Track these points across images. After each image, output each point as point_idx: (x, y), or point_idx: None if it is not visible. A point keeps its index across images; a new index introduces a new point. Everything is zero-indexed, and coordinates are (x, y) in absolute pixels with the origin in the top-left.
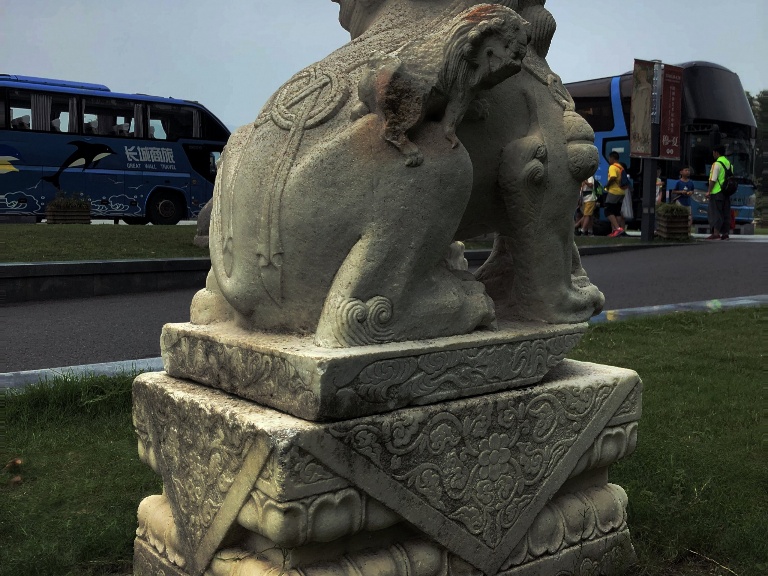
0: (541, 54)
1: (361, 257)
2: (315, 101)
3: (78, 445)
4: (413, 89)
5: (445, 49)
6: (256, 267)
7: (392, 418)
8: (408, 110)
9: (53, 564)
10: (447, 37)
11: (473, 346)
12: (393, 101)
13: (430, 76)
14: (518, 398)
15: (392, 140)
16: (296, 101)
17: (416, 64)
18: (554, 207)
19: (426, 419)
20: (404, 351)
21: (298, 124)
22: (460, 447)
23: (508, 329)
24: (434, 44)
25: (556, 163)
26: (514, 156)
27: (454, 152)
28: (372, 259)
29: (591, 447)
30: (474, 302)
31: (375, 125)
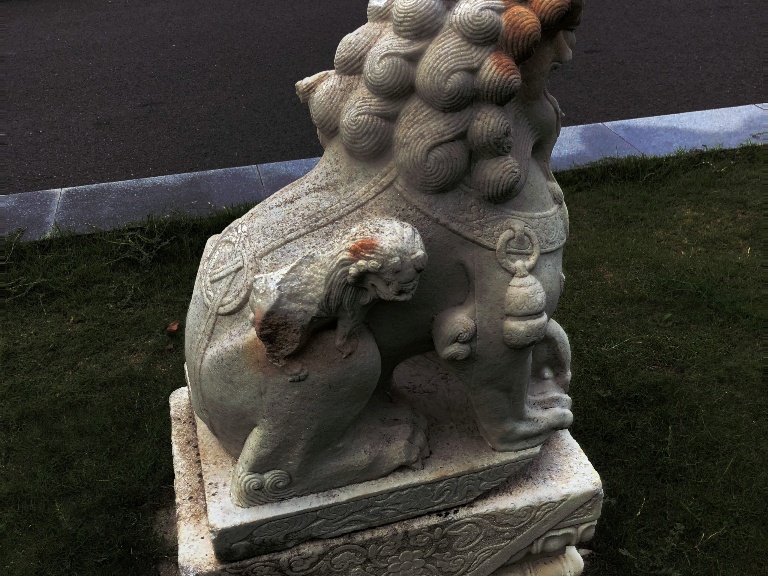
0: (504, 201)
1: (256, 443)
2: (228, 287)
3: None
4: (289, 322)
5: (327, 278)
6: (197, 404)
7: (290, 554)
8: (286, 340)
9: (134, 496)
10: (333, 263)
11: (382, 493)
12: (268, 335)
13: (310, 306)
14: (434, 525)
15: (273, 362)
16: (216, 279)
17: (297, 293)
18: (488, 373)
19: (327, 551)
20: (299, 511)
21: (213, 308)
22: (366, 564)
23: (437, 463)
24: (319, 270)
25: (488, 339)
26: (437, 335)
27: (346, 361)
28: (265, 446)
29: (529, 545)
30: (391, 453)
31: (261, 342)
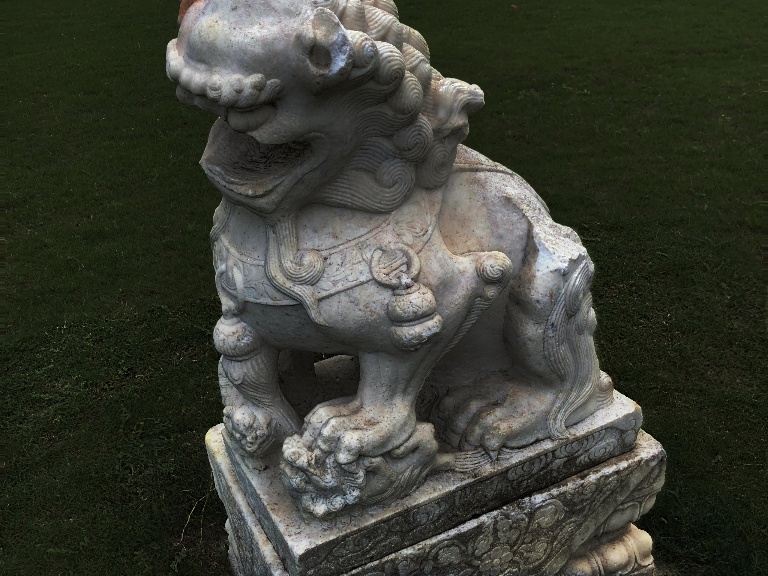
0: None
1: None
2: None
3: None
4: None
5: None
6: None
7: None
8: None
9: (718, 568)
10: None
11: None
12: None
13: None
14: None
15: None
16: None
17: None
18: None
19: None
20: None
21: None
22: None
23: (346, 357)
24: None
25: None
26: None
27: None
28: None
29: None
30: None
31: None
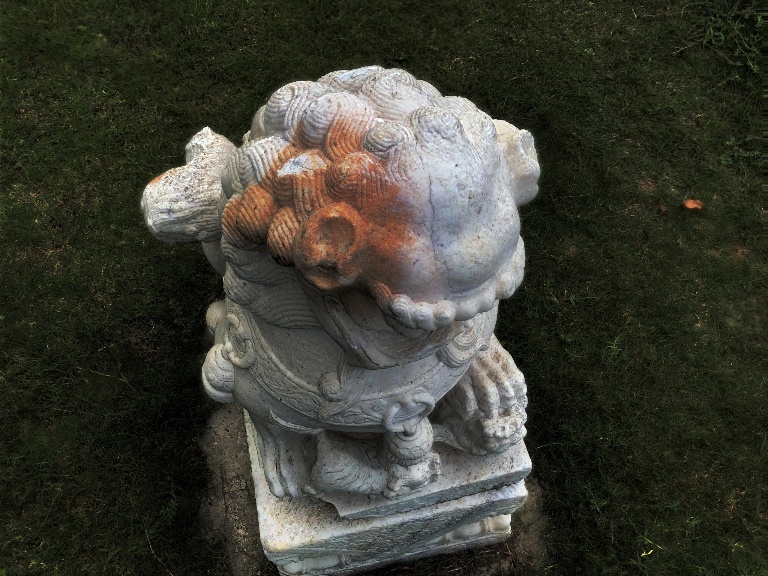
0: None
1: None
2: None
3: (764, 256)
4: None
5: None
6: None
7: None
8: None
9: None
10: None
11: None
12: None
13: None
14: None
15: None
16: None
17: None
18: None
19: None
20: None
21: None
22: None
23: None
24: None
25: None
26: None
27: None
28: None
29: None
30: None
31: None
